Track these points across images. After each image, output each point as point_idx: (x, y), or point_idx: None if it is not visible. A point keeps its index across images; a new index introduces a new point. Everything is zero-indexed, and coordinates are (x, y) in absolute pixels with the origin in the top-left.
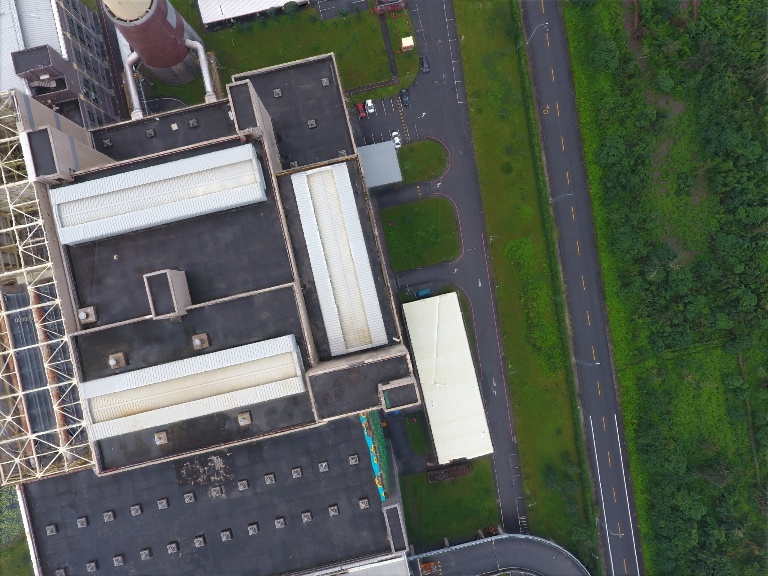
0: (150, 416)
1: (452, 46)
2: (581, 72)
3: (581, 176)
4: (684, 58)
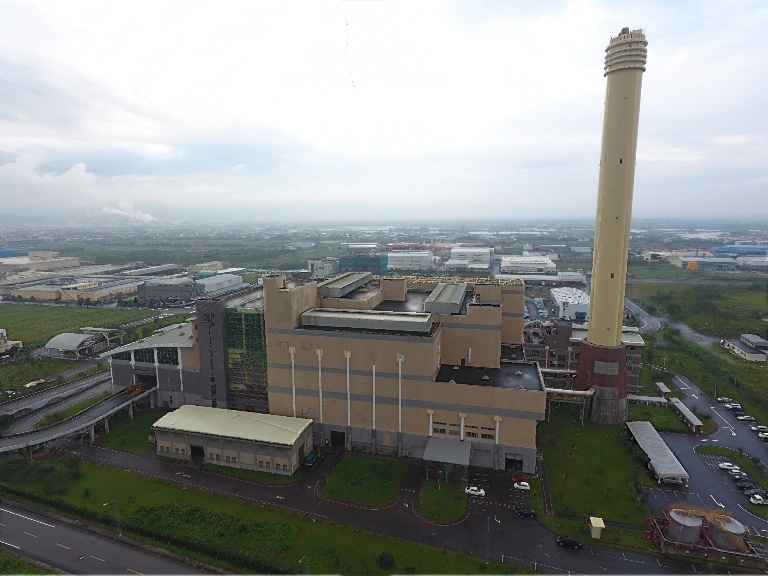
0: None
1: None
2: None
3: None
4: None
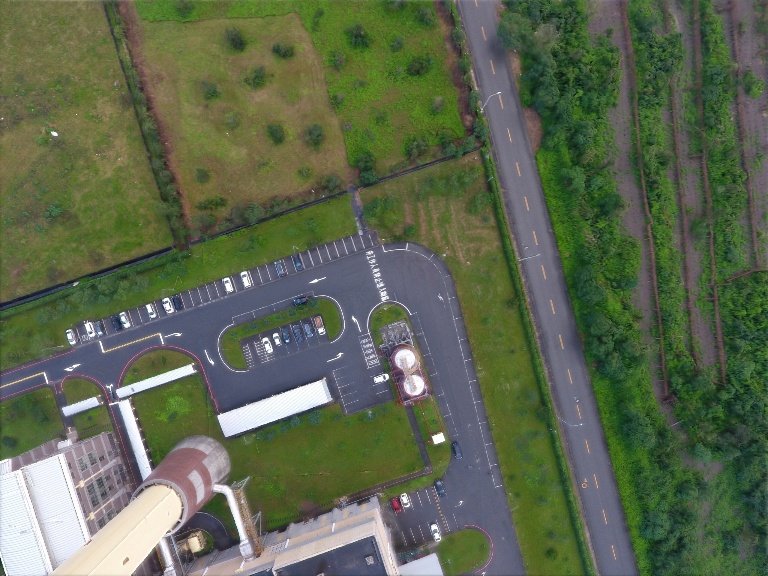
0: None
1: (483, 429)
2: (616, 444)
3: (627, 548)
4: (718, 422)
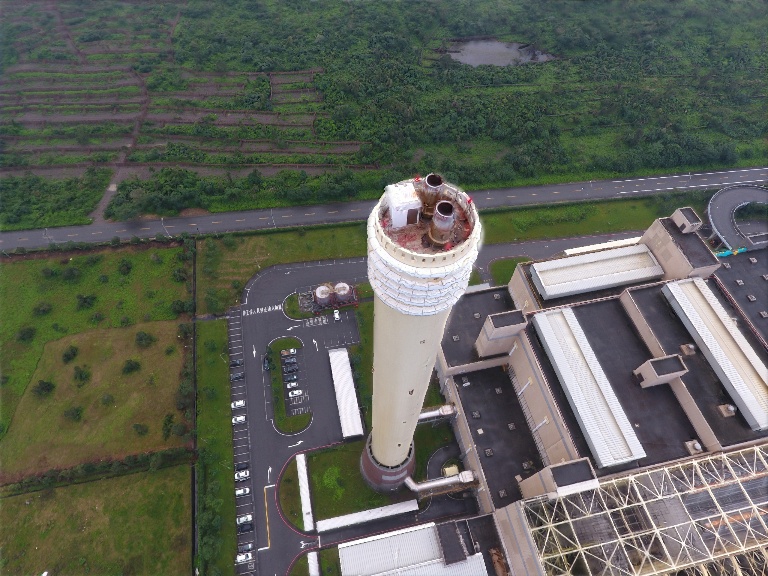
0: (763, 374)
1: None
2: None
3: None
4: None
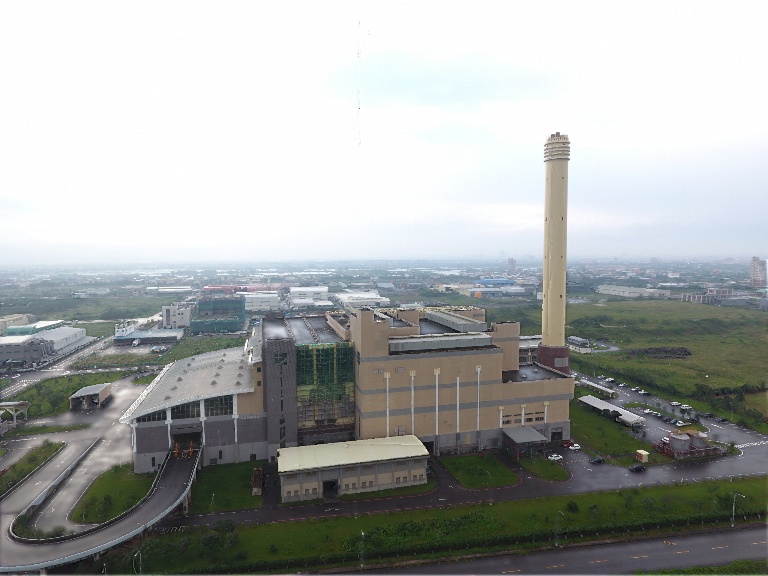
0: None
1: None
2: (750, 567)
3: (610, 574)
4: None
